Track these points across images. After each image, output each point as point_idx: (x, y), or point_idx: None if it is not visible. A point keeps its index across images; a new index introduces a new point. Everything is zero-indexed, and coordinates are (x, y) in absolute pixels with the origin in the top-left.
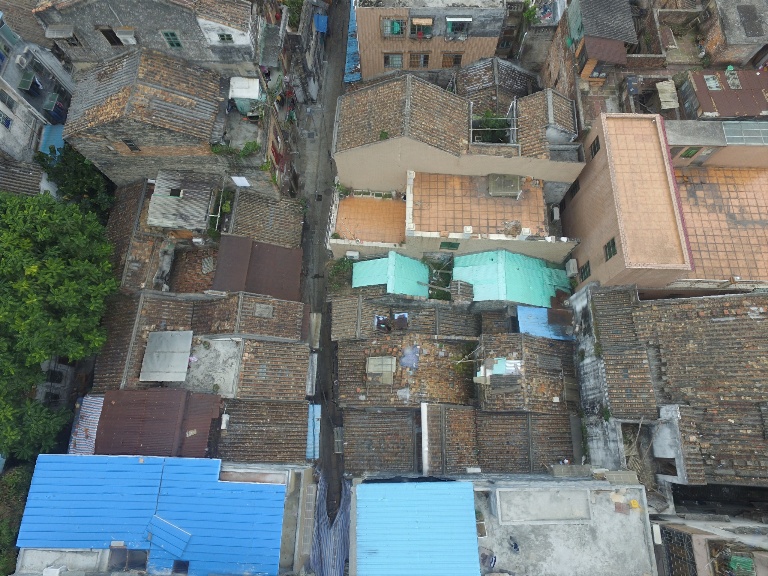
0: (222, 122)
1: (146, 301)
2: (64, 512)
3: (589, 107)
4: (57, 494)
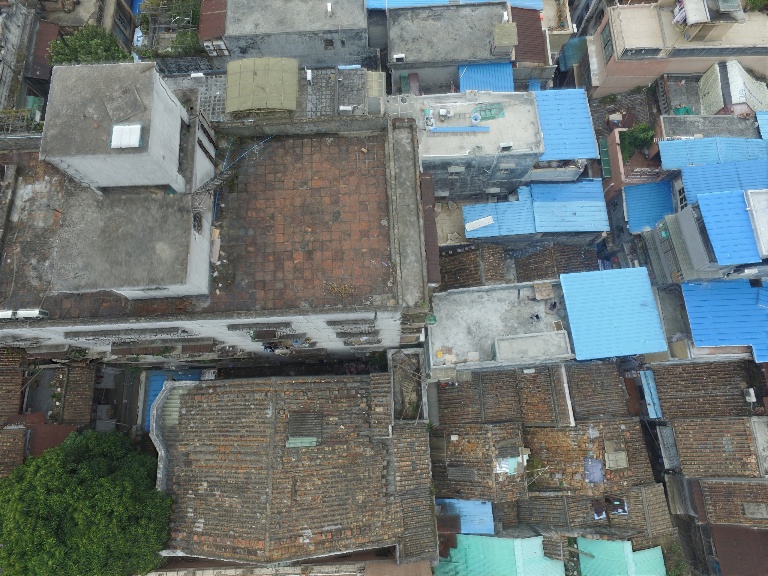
0: None
1: None
2: None
3: None
4: None
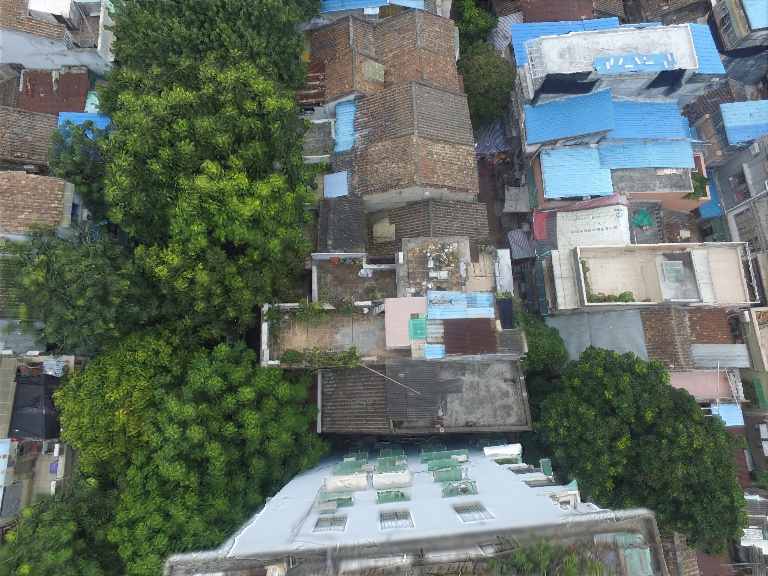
0: None
1: None
2: None
3: None
4: None
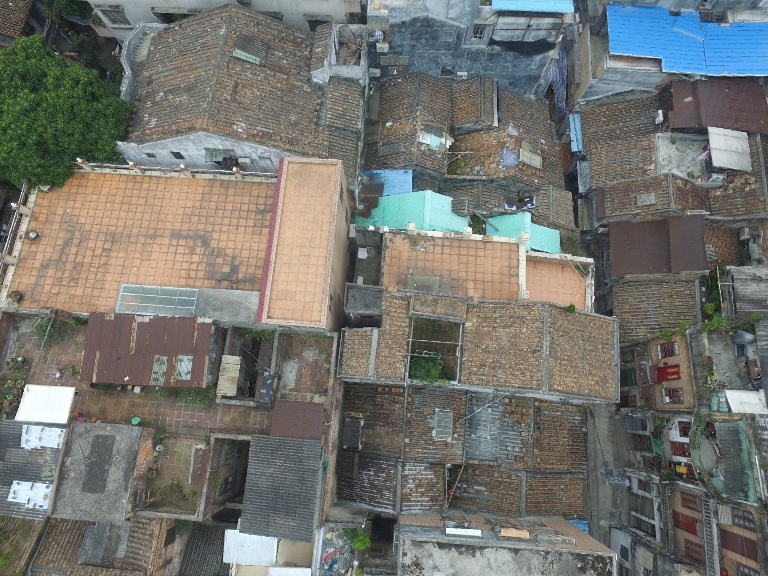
0: (761, 350)
1: (763, 209)
2: None
3: (316, 377)
4: None
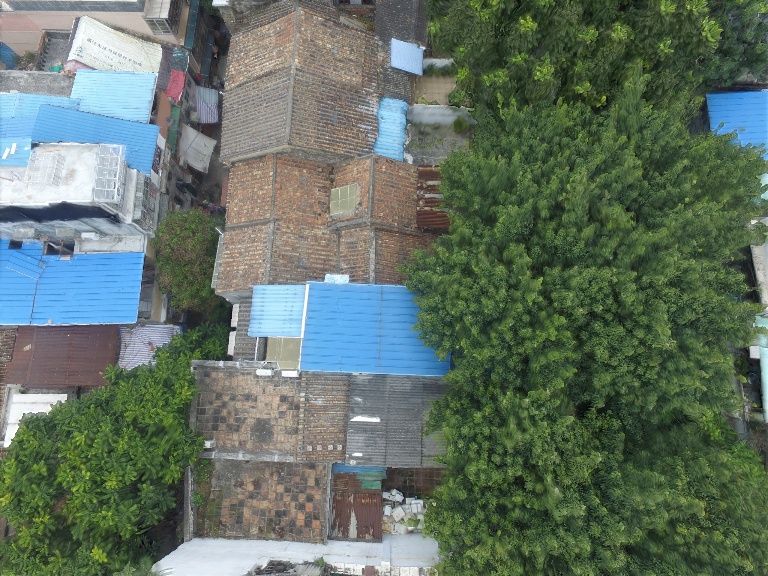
0: None
1: None
2: (110, 279)
3: None
4: (117, 292)
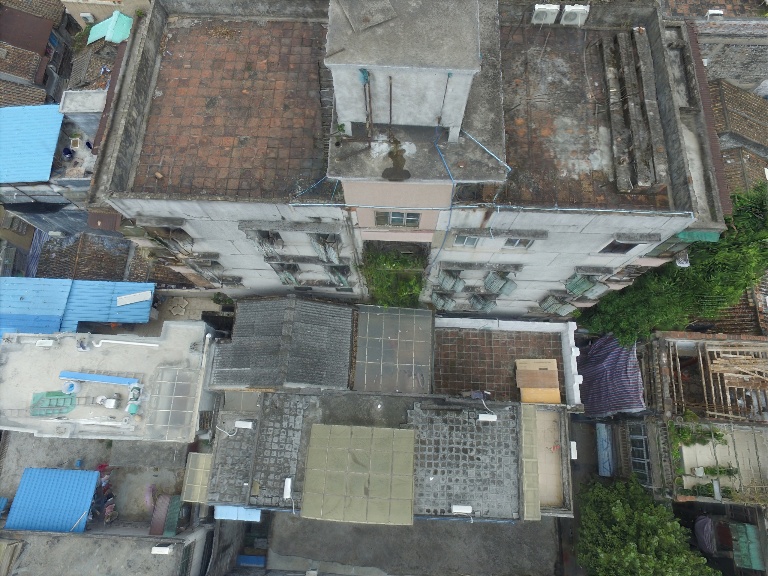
0: None
1: None
2: None
3: None
4: None
